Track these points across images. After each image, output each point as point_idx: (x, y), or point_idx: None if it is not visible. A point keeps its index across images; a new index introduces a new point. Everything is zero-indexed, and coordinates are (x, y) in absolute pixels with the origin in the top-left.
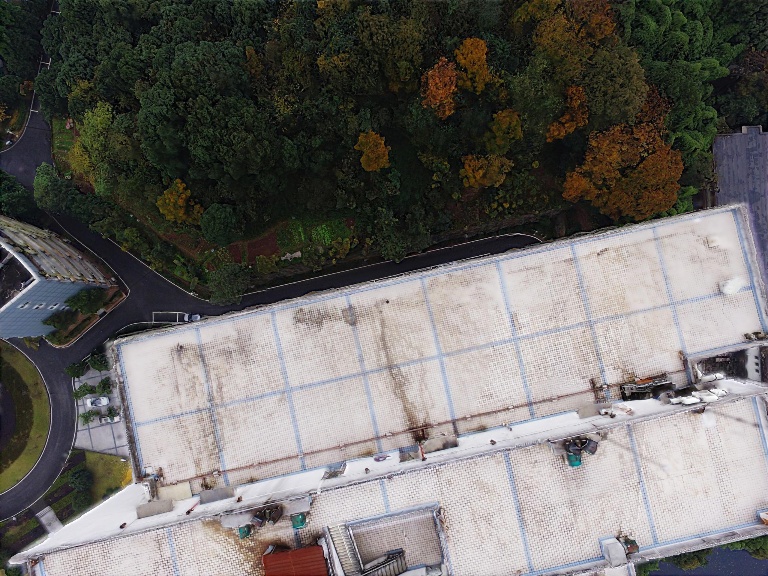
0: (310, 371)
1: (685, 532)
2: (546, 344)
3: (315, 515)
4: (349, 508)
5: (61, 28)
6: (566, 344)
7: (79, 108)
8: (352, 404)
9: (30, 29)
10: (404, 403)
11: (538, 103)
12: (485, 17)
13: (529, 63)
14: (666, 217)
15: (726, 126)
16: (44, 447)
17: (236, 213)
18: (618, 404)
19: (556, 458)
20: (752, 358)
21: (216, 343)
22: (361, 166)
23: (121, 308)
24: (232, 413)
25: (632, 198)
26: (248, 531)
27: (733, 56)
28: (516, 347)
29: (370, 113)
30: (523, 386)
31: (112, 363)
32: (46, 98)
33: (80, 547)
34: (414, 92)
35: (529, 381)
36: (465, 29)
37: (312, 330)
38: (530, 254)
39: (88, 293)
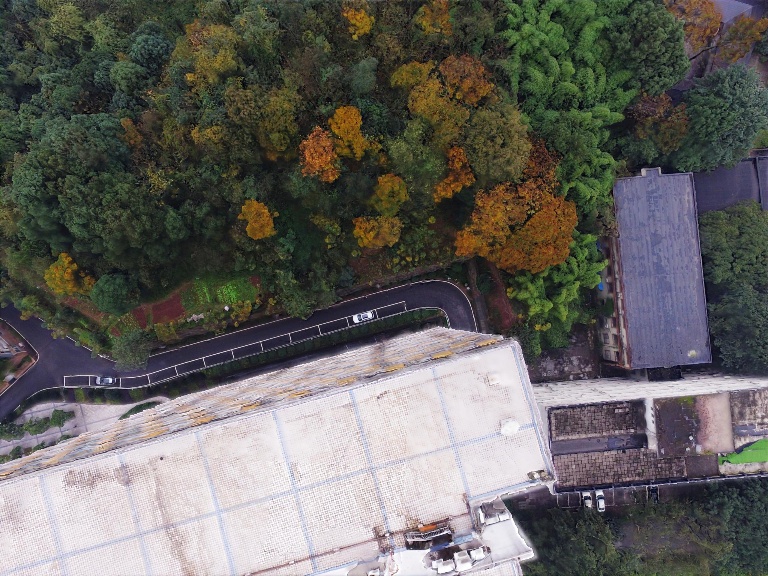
0: (81, 536)
1: None
2: (327, 494)
3: None
4: None
5: None
6: (347, 493)
7: None
8: (127, 568)
9: None
10: (181, 564)
11: (421, 166)
12: (358, 84)
13: (405, 129)
14: (440, 360)
15: (625, 169)
16: None
17: (129, 282)
18: (399, 555)
19: None
20: (649, 409)
21: None
22: None
23: (31, 373)
24: None
25: (523, 254)
26: None
27: (626, 101)
28: (296, 499)
29: (255, 180)
30: (304, 539)
31: (22, 432)
32: None
33: None
34: (295, 159)
35: (310, 533)
36: (343, 94)
37: (82, 493)
38: (308, 401)
39: None
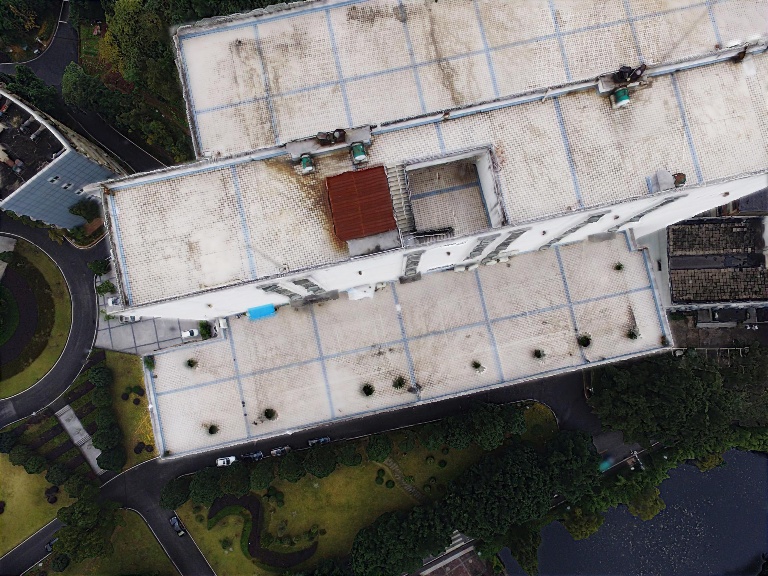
0: (362, 64)
1: (729, 171)
2: (588, 39)
3: (374, 156)
4: (406, 150)
5: None
6: (607, 39)
7: None
8: (403, 94)
9: None
10: (452, 93)
11: None
12: None
13: None
14: None
15: None
16: (65, 346)
17: None
18: None
19: (604, 104)
20: None
21: (273, 38)
22: None
23: None
24: (288, 102)
25: None
26: (311, 162)
27: None
28: (559, 42)
29: None
30: (566, 77)
31: None
32: None
33: (149, 185)
34: None
35: (572, 73)
36: None
37: (364, 26)
38: None
39: None
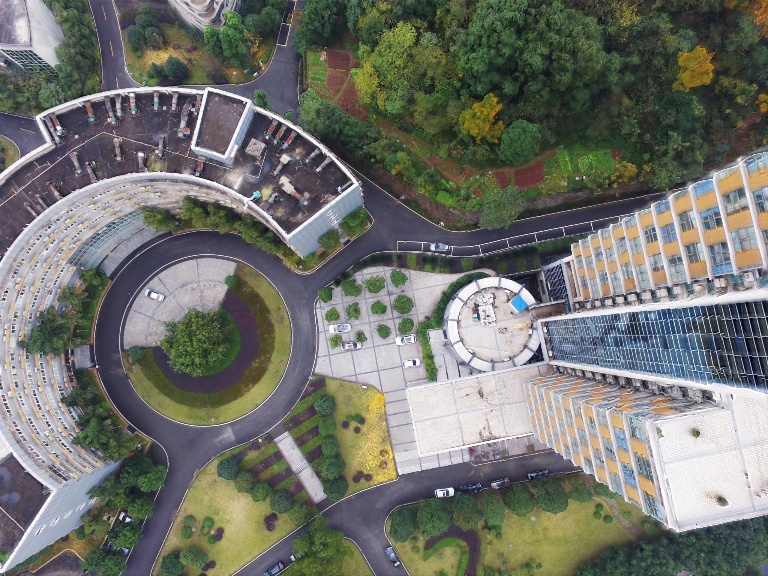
0: None
1: None
2: None
3: None
4: None
5: None
6: None
7: (378, 28)
8: None
9: None
10: None
11: None
12: None
13: None
14: None
15: None
16: (284, 372)
17: None
18: None
19: None
20: None
21: None
22: (646, 94)
23: (364, 237)
24: None
25: None
26: None
27: None
28: None
29: None
30: None
31: (360, 289)
32: (317, 26)
33: None
34: (741, 12)
35: None
36: None
37: None
38: None
39: None
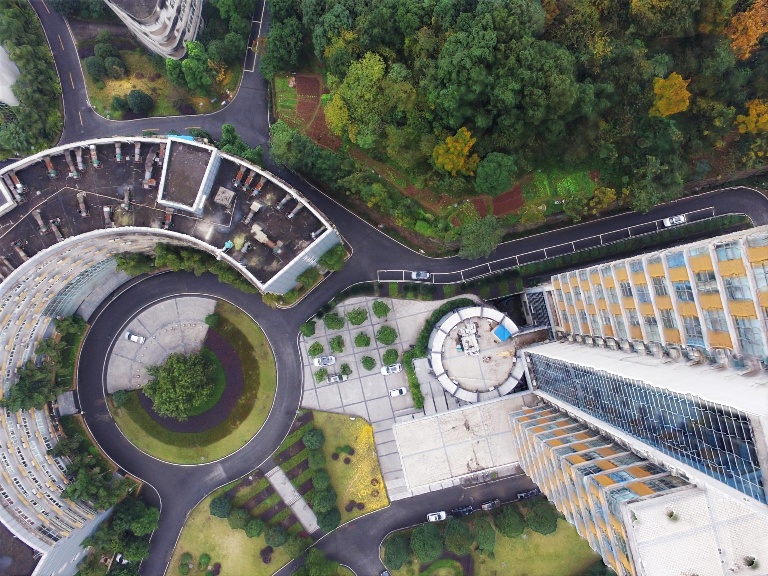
0: None
1: None
2: None
3: None
4: None
5: None
6: None
7: (345, 59)
8: None
9: None
10: None
11: None
12: None
13: None
14: None
15: None
16: (271, 408)
17: None
18: None
19: None
20: None
21: None
22: None
23: (344, 268)
24: None
25: None
26: None
27: None
28: None
29: None
30: None
31: (343, 322)
32: (283, 54)
33: None
34: None
35: None
36: None
37: None
38: None
39: None
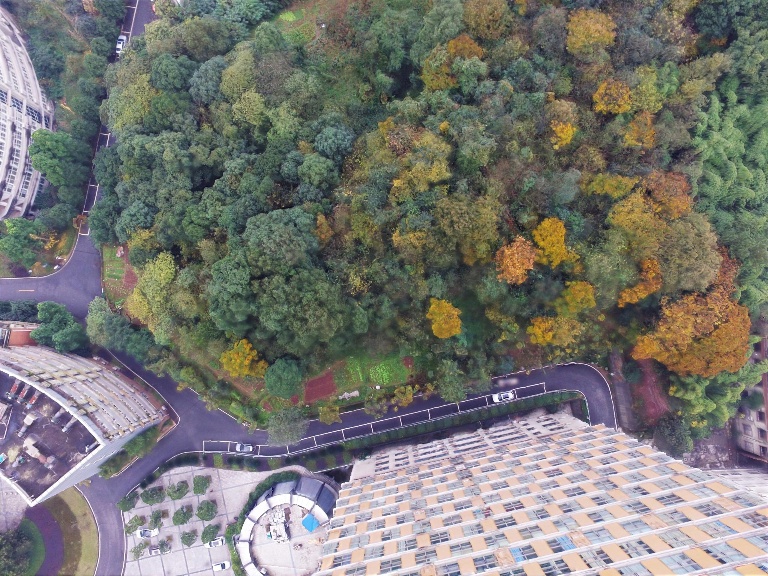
0: None
1: None
2: None
3: None
4: None
5: (115, 162)
6: None
7: (140, 258)
8: None
9: (81, 157)
10: None
11: (612, 274)
12: (563, 197)
13: (607, 242)
14: None
15: None
16: None
17: (300, 367)
18: None
19: None
20: None
21: None
22: None
23: (171, 436)
24: None
25: (704, 362)
26: None
27: None
28: None
29: None
30: None
31: (163, 496)
32: (100, 234)
33: None
34: (487, 263)
35: None
36: None
37: None
38: None
39: (144, 436)
